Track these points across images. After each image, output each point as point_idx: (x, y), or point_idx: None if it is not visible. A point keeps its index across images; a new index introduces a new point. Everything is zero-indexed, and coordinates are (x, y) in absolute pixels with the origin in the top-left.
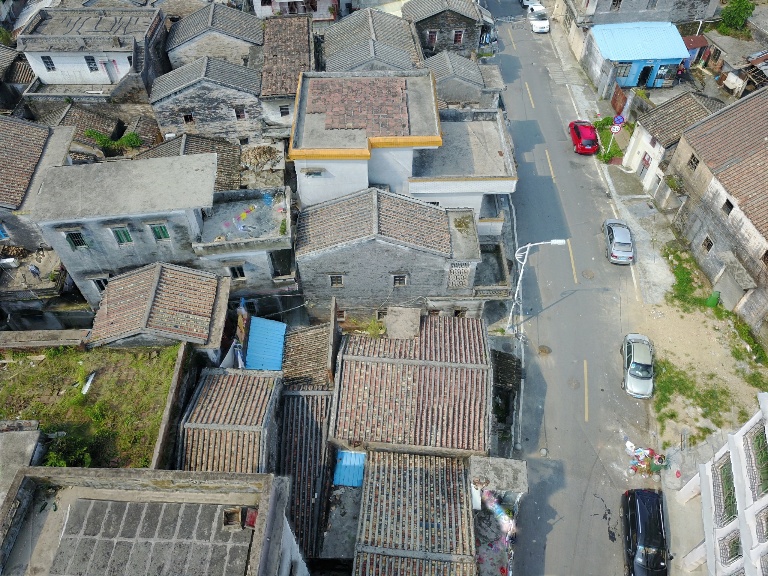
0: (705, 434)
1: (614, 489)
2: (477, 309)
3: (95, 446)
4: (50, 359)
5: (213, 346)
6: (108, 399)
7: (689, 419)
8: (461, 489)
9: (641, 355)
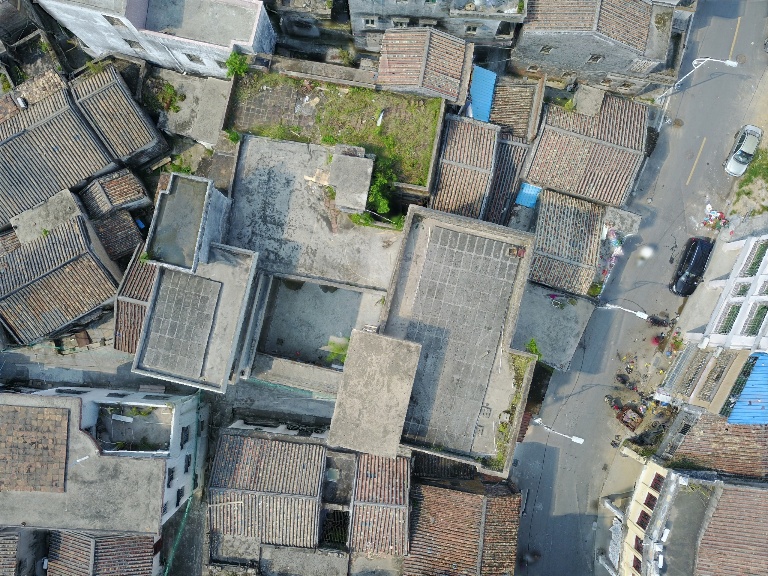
0: (764, 211)
1: (685, 233)
2: (642, 86)
3: (391, 166)
4: (353, 94)
5: (460, 103)
6: (396, 134)
7: (758, 198)
8: (597, 226)
9: (749, 146)
